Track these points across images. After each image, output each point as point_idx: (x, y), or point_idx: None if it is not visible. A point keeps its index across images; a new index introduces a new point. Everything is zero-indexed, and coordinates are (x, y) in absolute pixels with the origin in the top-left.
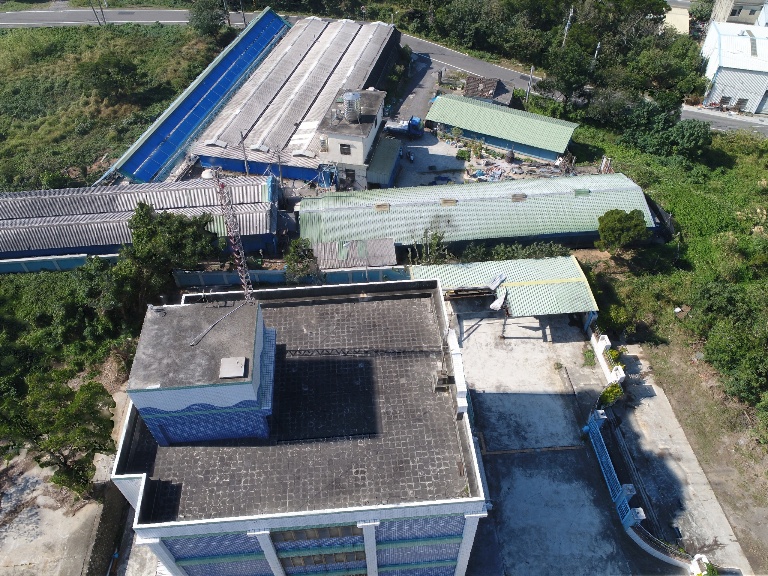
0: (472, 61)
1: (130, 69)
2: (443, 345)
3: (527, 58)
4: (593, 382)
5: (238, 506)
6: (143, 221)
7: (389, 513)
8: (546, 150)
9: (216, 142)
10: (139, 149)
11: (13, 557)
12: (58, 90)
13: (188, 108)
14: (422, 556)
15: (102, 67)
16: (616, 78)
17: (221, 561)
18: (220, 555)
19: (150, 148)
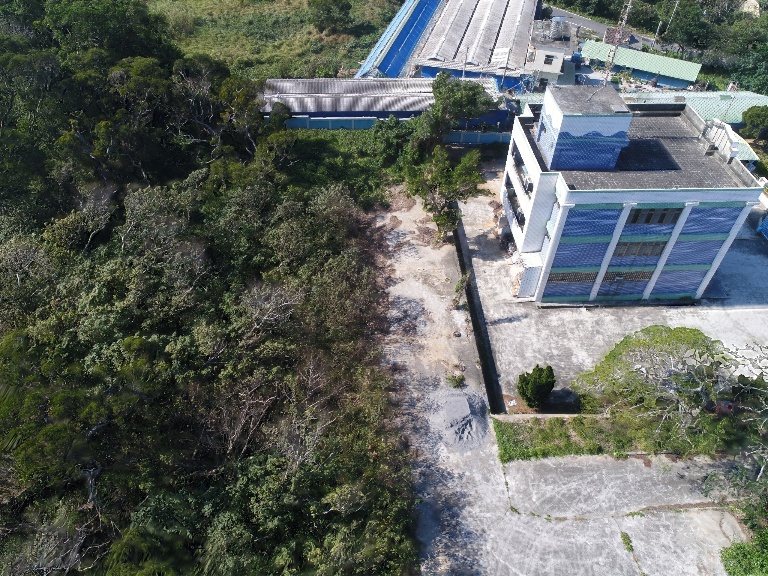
0: (596, 24)
1: (349, 7)
2: (702, 134)
3: (641, 23)
4: (756, 208)
5: None
6: (445, 82)
7: (707, 196)
8: (679, 80)
9: (437, 57)
10: (385, 56)
11: (411, 266)
12: (282, 23)
13: (405, 34)
14: (694, 256)
15: (328, 4)
16: (727, 33)
17: (585, 240)
18: (586, 235)
19: (390, 57)
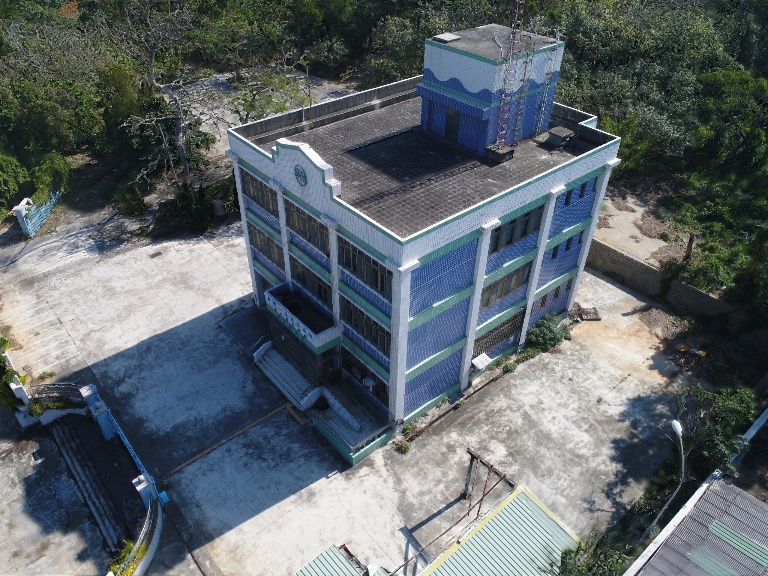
0: None
1: None
2: None
3: None
4: None
5: (398, 108)
6: None
7: None
8: None
9: None
10: None
11: None
12: None
13: None
14: None
15: None
16: None
17: None
18: None
19: None
